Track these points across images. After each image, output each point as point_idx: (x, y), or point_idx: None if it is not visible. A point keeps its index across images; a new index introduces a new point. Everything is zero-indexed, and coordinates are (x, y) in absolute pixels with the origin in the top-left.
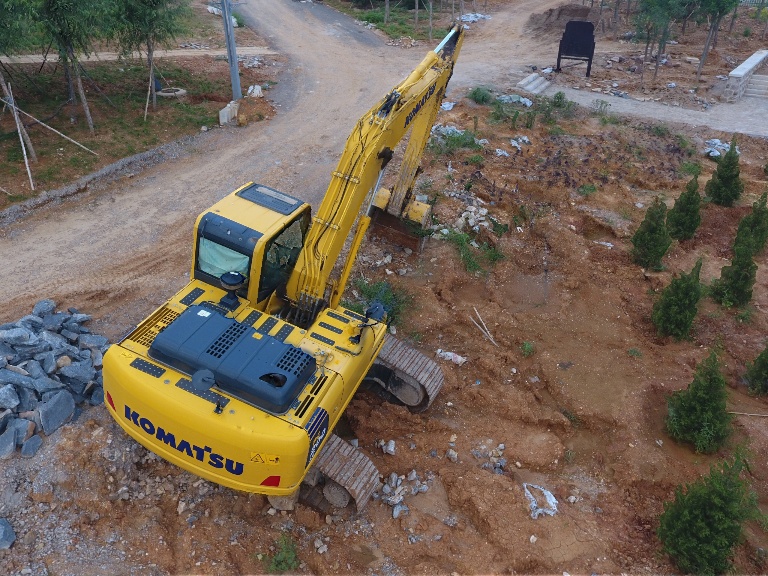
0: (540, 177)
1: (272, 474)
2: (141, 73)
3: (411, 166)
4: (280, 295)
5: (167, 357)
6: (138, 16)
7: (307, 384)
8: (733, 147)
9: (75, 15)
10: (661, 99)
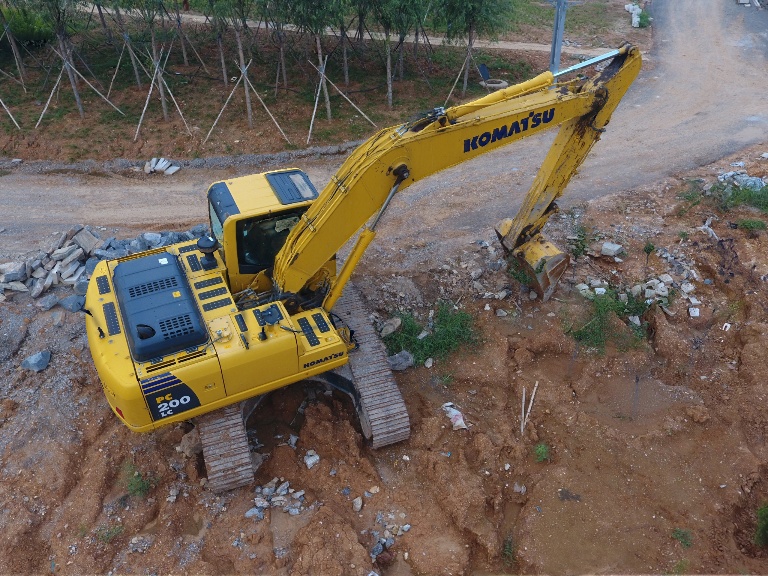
0: None
1: (117, 406)
2: (484, 62)
3: (533, 200)
4: (269, 275)
5: None
6: (458, 8)
7: (184, 351)
8: None
9: (387, 3)
10: None
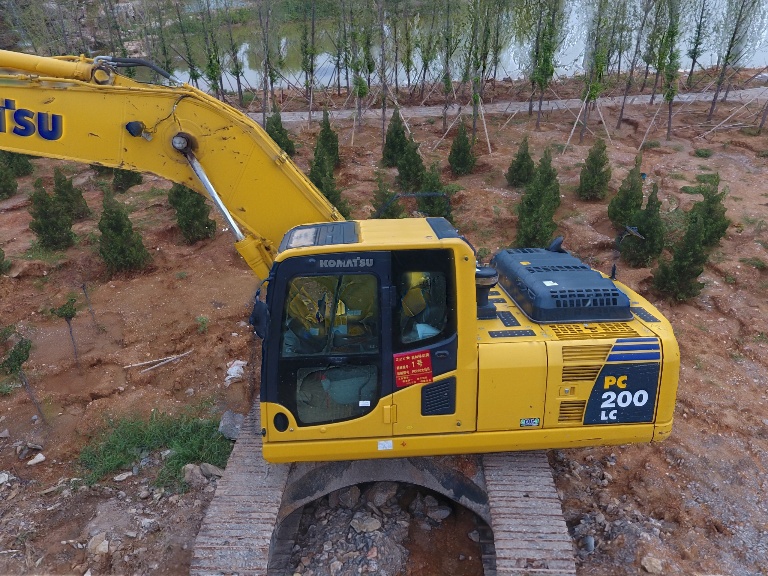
0: None
1: None
2: None
3: None
4: None
5: None
6: None
7: None
8: None
9: None
10: None
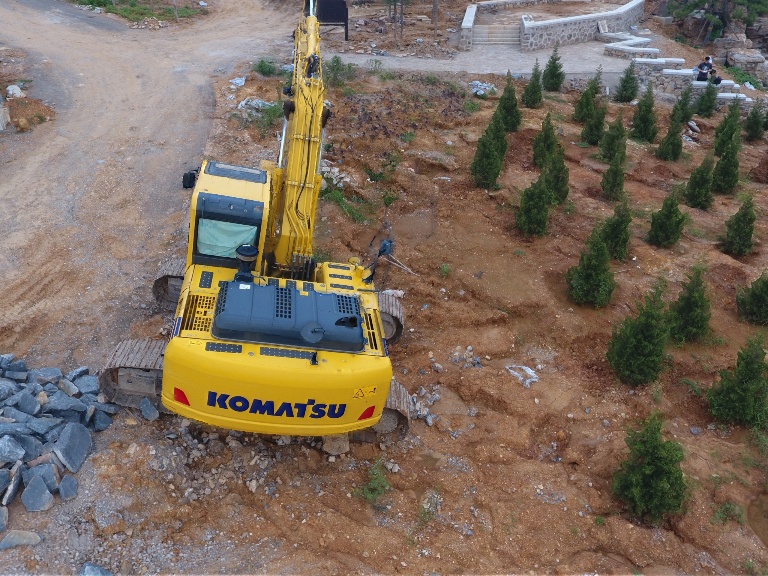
0: (364, 133)
1: (369, 406)
2: None
3: None
4: (270, 264)
5: (239, 332)
6: None
7: None
8: (509, 82)
9: None
10: (416, 53)
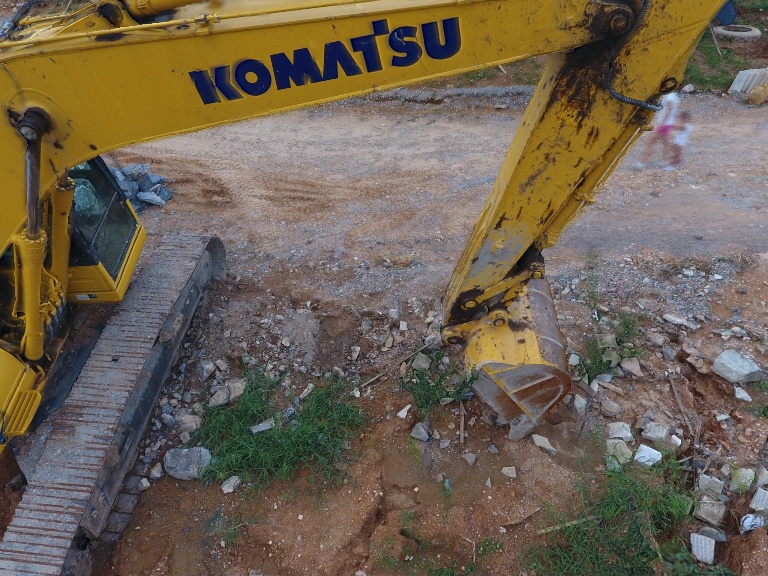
0: None
1: None
2: None
3: (475, 241)
4: None
5: None
6: None
7: None
8: None
9: None
10: None
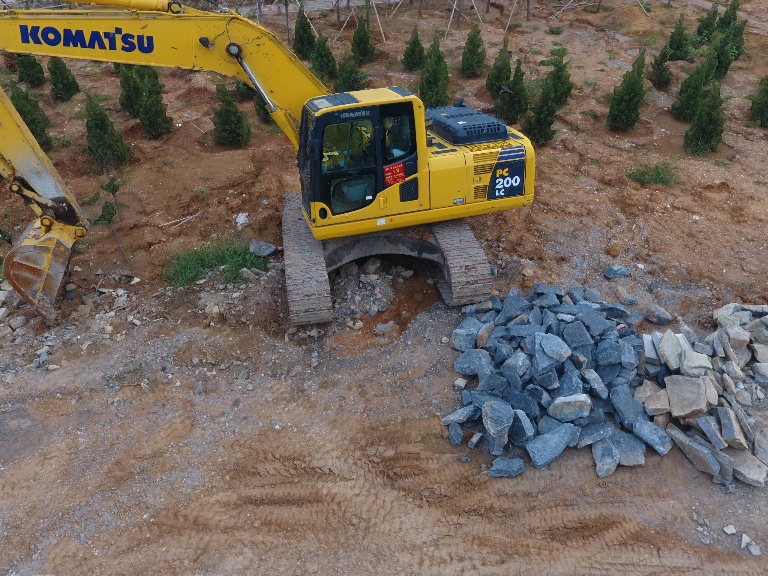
0: None
1: None
2: None
3: None
4: None
5: None
6: None
7: None
8: None
9: None
10: None
